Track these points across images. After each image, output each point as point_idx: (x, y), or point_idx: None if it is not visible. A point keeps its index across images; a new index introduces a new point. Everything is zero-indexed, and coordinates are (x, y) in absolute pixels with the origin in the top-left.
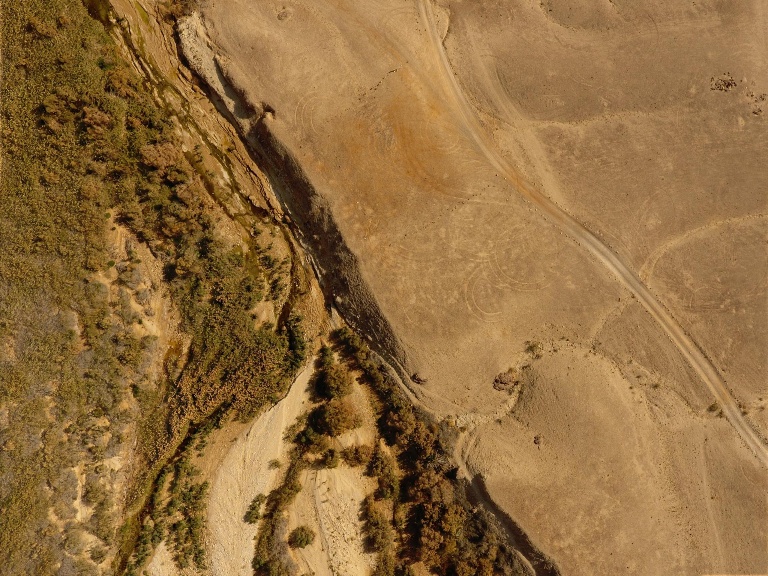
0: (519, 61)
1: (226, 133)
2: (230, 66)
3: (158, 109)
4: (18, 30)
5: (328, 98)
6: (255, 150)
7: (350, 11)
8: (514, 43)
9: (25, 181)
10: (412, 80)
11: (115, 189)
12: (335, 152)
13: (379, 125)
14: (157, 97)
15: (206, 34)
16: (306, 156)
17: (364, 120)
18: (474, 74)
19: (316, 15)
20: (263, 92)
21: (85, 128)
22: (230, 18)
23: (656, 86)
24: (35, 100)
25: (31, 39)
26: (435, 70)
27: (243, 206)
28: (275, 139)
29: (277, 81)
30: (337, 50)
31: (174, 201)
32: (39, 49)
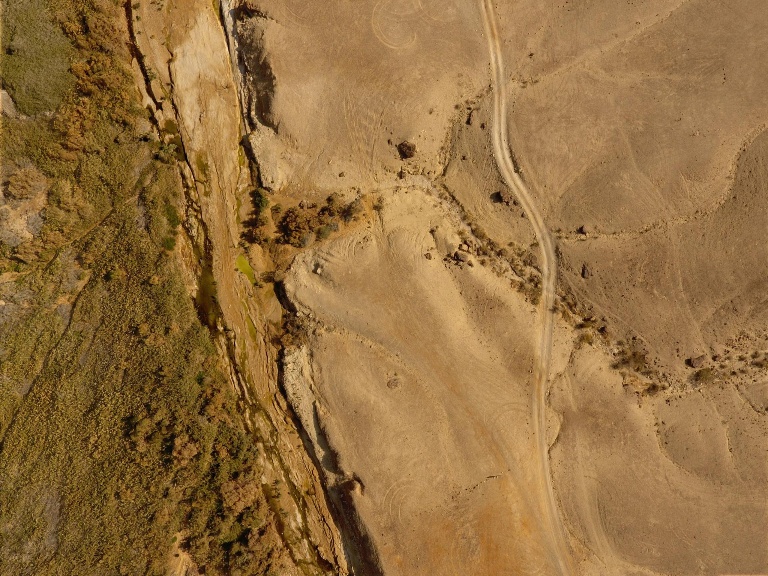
0: (623, 497)
1: (308, 475)
2: (329, 422)
3: (246, 435)
4: (125, 329)
5: (421, 490)
6: (334, 504)
7: (462, 397)
8: (622, 473)
9: (101, 492)
10: (510, 490)
11: (187, 512)
12: (416, 550)
13: (467, 531)
14: (248, 419)
15: (311, 376)
16: (386, 546)
17: (453, 522)
18: (574, 494)
19: (427, 391)
20: (357, 462)
21: (171, 453)
22: (339, 370)
23: (759, 565)
24: (127, 408)
25: (137, 343)
26: (535, 482)
27: (310, 555)
28: (359, 517)
29: (373, 456)
30: (440, 436)
31: (243, 544)
32: (142, 353)
